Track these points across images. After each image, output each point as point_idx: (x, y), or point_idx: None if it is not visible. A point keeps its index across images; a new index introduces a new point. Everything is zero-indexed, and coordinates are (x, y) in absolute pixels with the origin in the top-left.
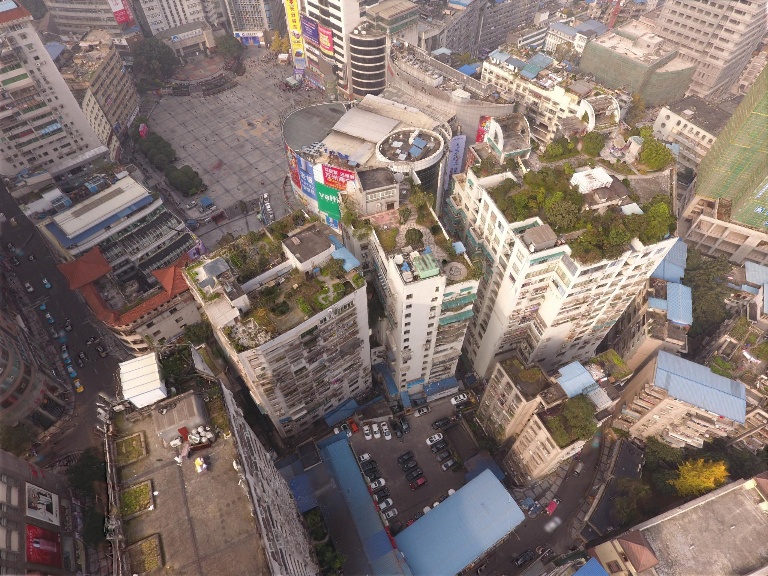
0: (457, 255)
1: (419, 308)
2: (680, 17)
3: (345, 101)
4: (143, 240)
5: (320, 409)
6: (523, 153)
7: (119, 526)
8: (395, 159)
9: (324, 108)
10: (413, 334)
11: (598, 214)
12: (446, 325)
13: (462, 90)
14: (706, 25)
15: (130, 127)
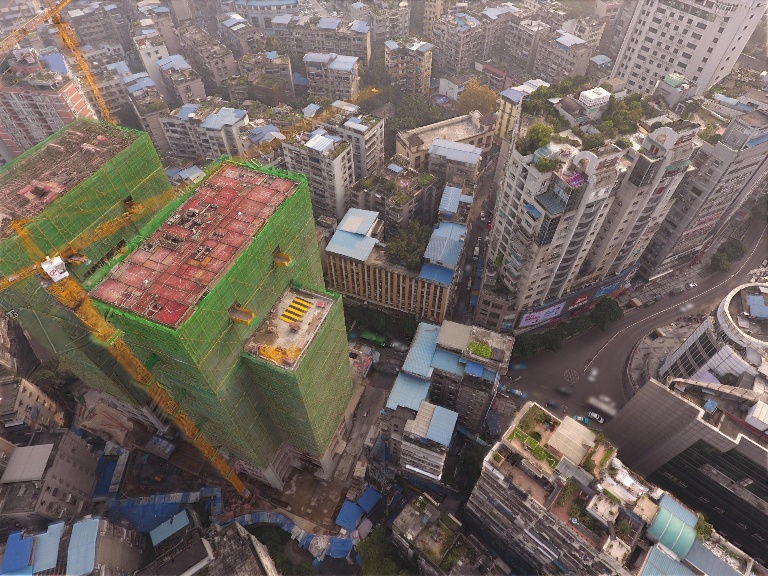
0: None
1: None
2: None
3: None
4: None
5: None
6: None
7: None
8: None
9: None
10: None
11: None
12: None
13: None
14: None
15: None
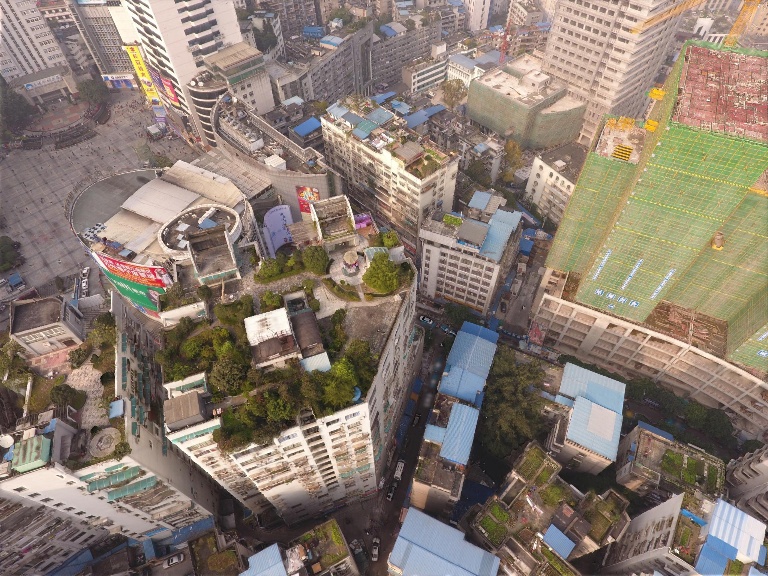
0: (117, 417)
1: (56, 492)
2: (564, 54)
3: (158, 168)
4: None
5: (29, 573)
6: None
7: None
8: None
9: (132, 177)
10: (84, 508)
11: (276, 369)
12: None
13: (277, 156)
14: (589, 63)
15: None
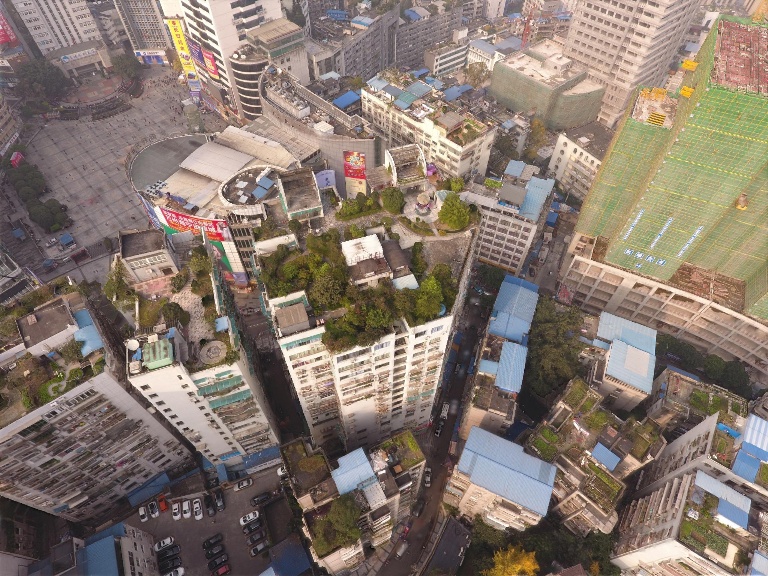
0: (222, 332)
1: (170, 395)
2: (586, 38)
3: None
4: None
5: (116, 489)
6: (314, 211)
7: None
8: (238, 201)
9: (184, 141)
10: (185, 417)
11: (370, 288)
12: (225, 406)
13: (325, 123)
14: (610, 47)
15: (5, 155)
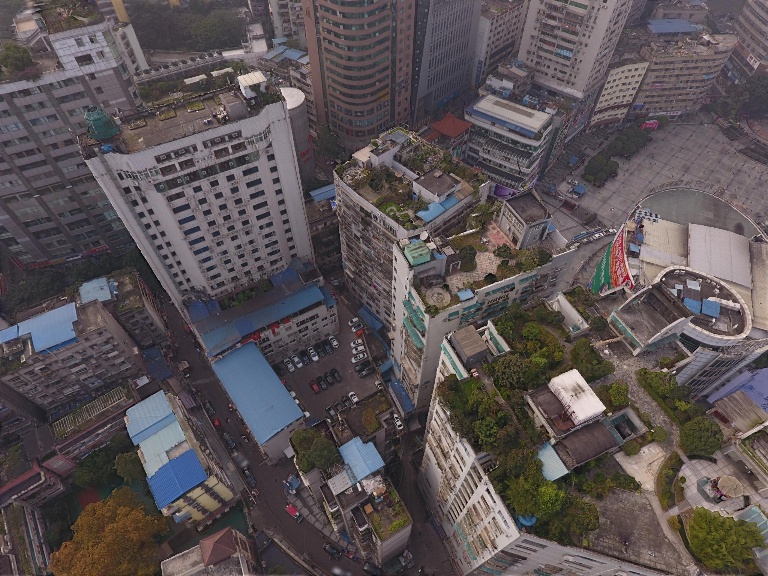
0: None
1: None
2: None
3: None
4: (497, 151)
5: (364, 295)
6: None
7: (180, 101)
8: None
9: (737, 218)
10: (397, 306)
11: (532, 419)
12: None
13: None
14: None
15: None
